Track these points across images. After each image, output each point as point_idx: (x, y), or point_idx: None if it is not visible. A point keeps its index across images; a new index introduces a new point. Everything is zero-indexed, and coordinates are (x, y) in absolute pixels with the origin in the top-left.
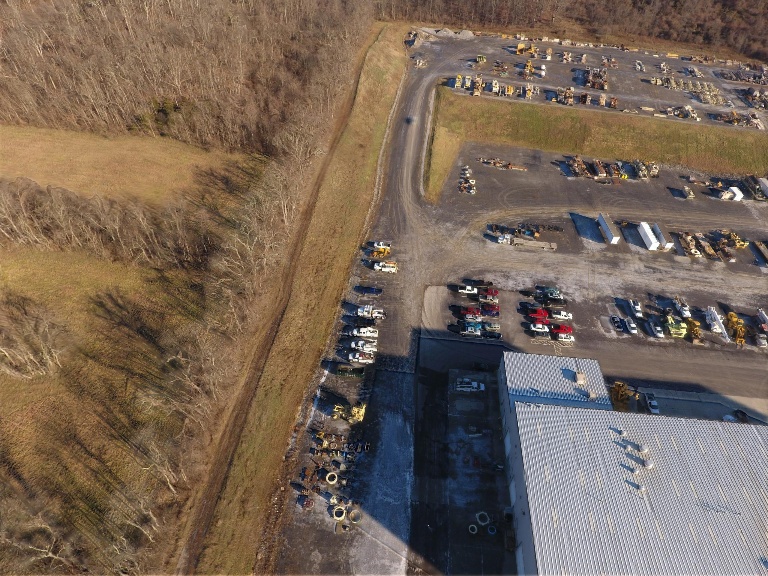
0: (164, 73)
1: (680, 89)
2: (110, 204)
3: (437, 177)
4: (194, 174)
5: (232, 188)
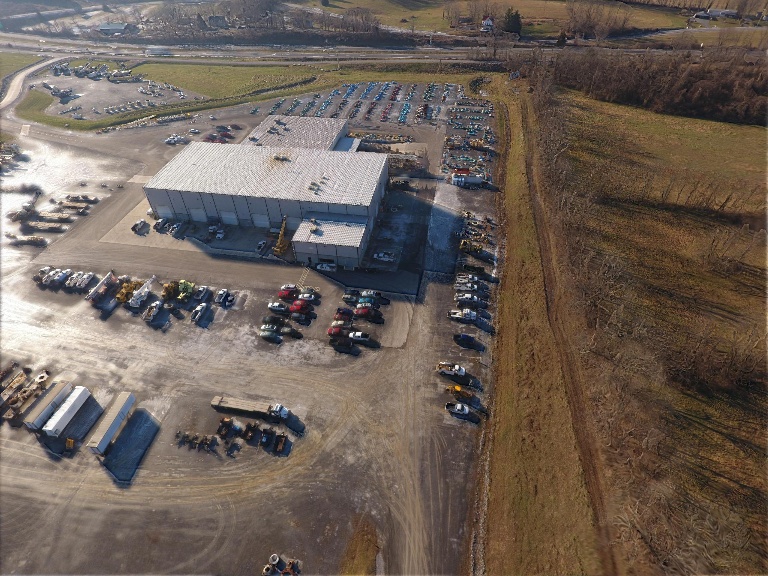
0: None
1: None
2: None
3: None
4: None
5: (763, 504)
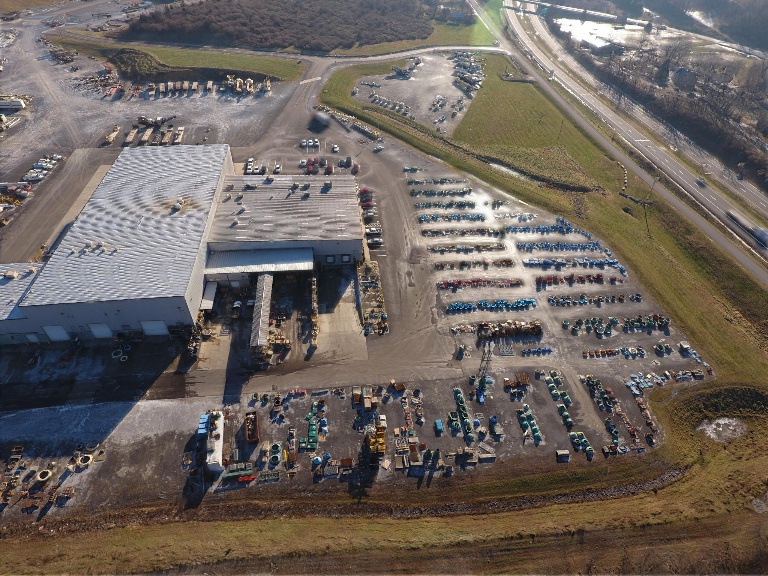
0: None
1: None
2: None
3: None
4: None
5: None
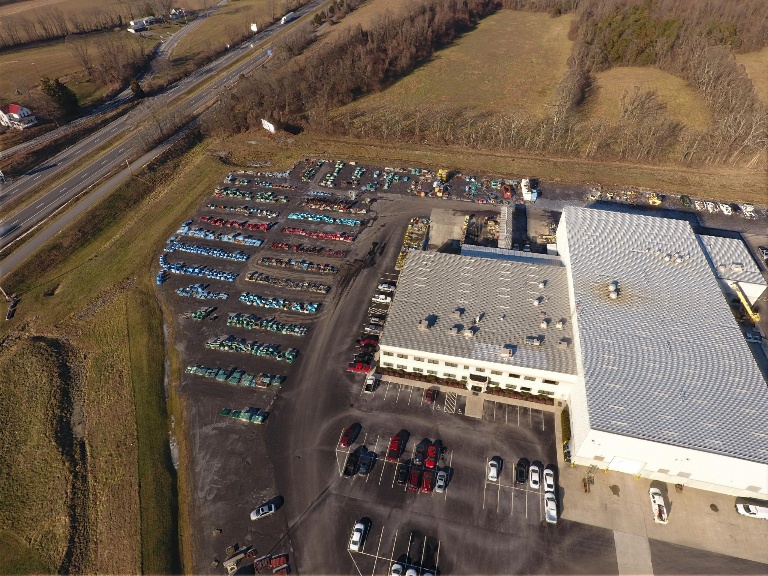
0: None
1: None
2: None
3: None
4: None
5: None
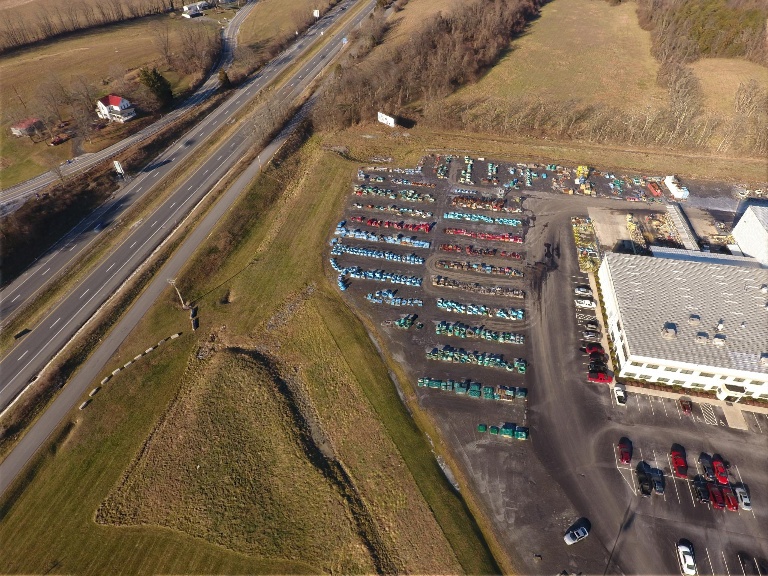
0: None
1: None
2: None
3: None
4: None
5: None
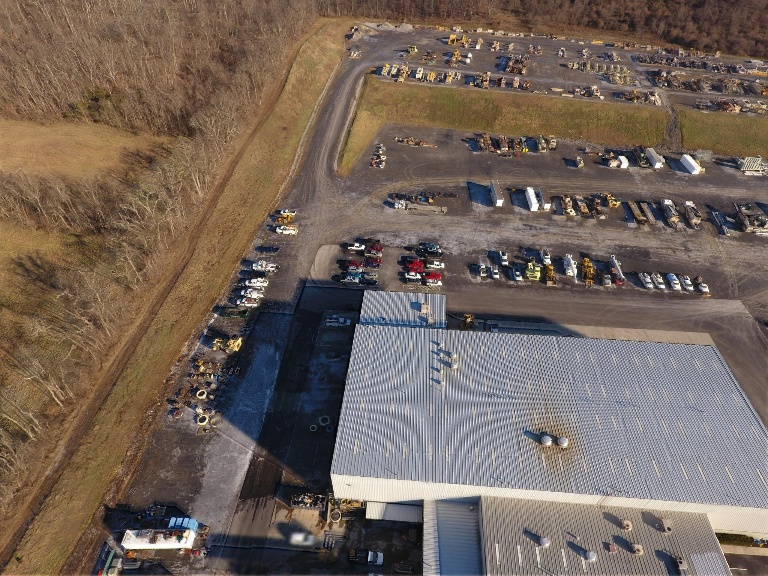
0: (98, 65)
1: (594, 72)
2: (40, 182)
3: (352, 154)
4: (121, 155)
5: (155, 166)
